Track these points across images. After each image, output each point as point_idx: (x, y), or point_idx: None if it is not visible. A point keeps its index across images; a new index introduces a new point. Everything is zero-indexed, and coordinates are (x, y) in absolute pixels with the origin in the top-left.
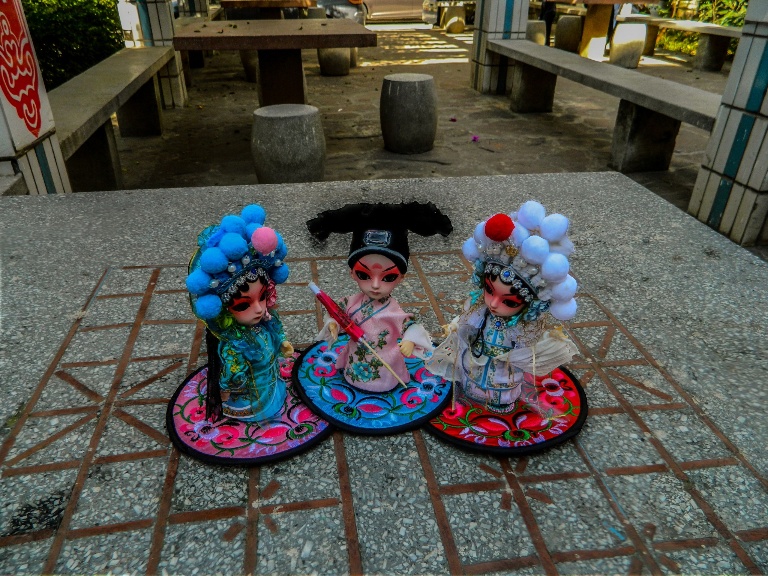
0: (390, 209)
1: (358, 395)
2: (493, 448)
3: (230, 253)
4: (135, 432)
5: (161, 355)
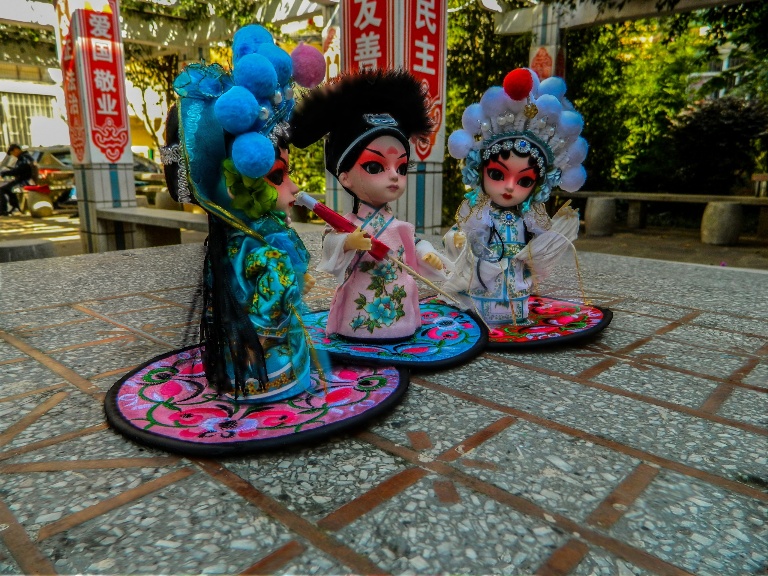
0: (392, 80)
1: (385, 346)
2: (577, 333)
3: (281, 65)
4: (85, 473)
5: (8, 396)
